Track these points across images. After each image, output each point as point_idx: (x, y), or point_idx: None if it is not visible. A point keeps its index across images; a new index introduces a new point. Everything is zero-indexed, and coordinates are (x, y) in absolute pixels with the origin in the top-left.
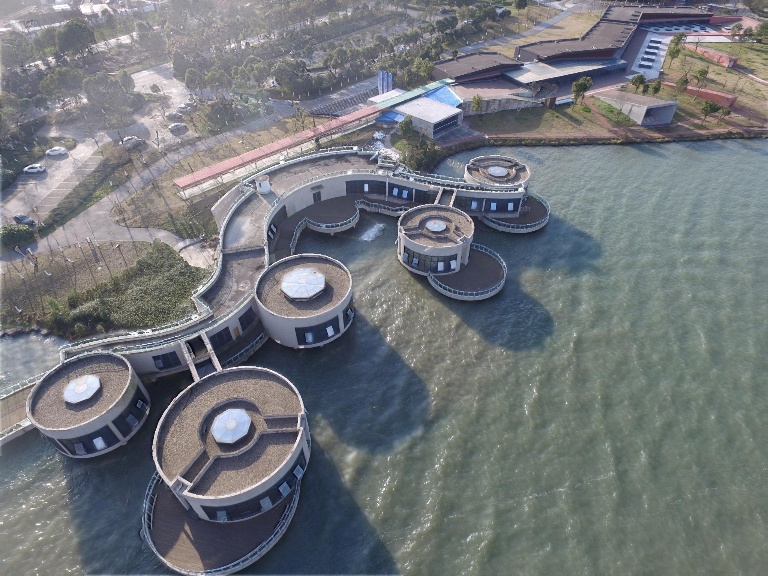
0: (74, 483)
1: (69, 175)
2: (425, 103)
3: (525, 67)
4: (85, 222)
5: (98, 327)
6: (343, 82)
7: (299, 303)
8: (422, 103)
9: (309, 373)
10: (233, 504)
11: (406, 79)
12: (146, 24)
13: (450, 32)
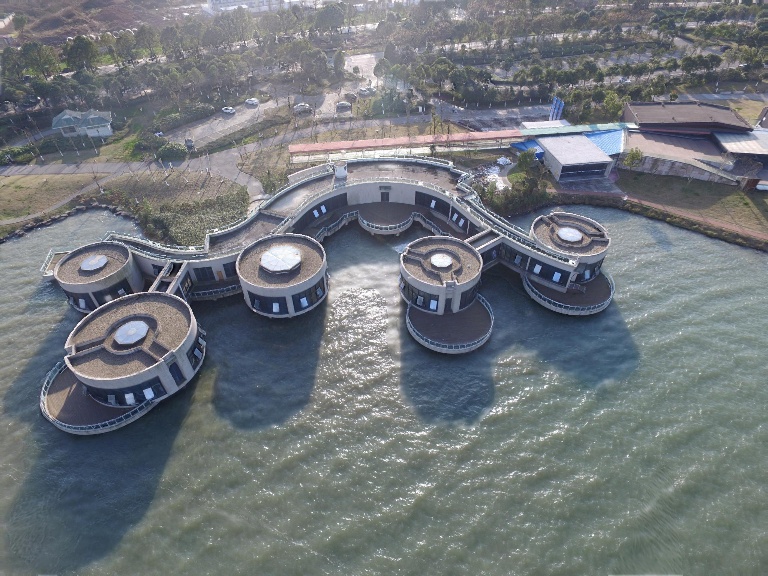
0: (63, 322)
1: (244, 121)
2: (578, 142)
3: (753, 133)
4: (221, 157)
5: (157, 231)
6: (523, 101)
7: (264, 272)
8: (574, 141)
9: (242, 333)
10: (87, 384)
11: (581, 112)
12: (396, 15)
13: (702, 73)
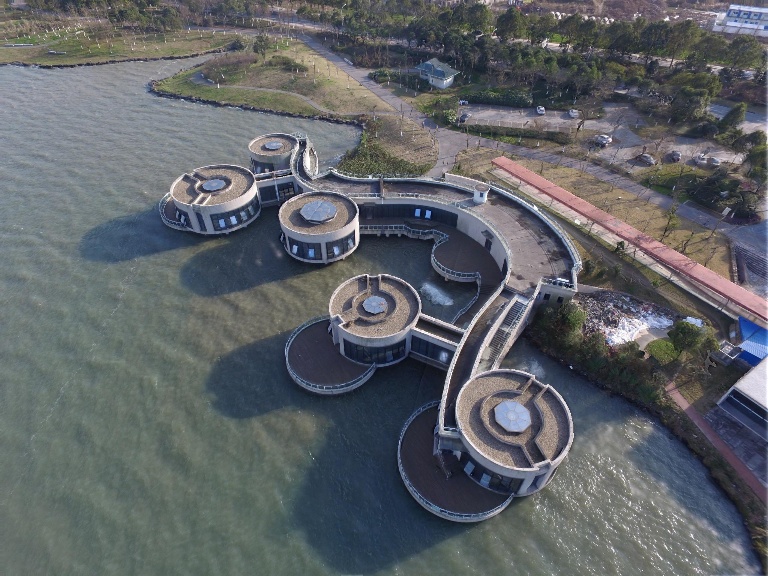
0: None
1: (535, 124)
2: None
3: None
4: (464, 139)
5: None
6: None
7: None
8: None
9: (265, 239)
10: None
11: None
12: None
13: None
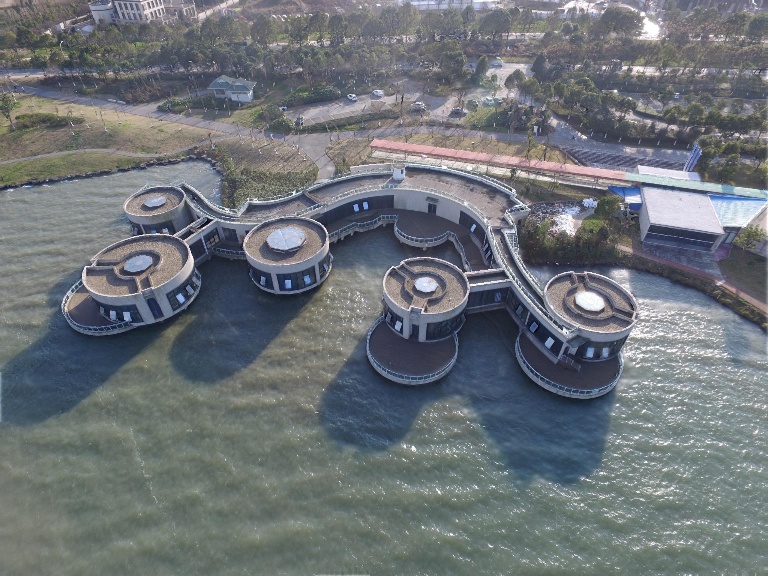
0: None
1: (359, 109)
2: (693, 202)
3: None
4: (318, 138)
5: None
6: (666, 142)
7: (266, 247)
8: (689, 200)
9: (233, 294)
10: None
11: None
12: (573, 26)
13: None
